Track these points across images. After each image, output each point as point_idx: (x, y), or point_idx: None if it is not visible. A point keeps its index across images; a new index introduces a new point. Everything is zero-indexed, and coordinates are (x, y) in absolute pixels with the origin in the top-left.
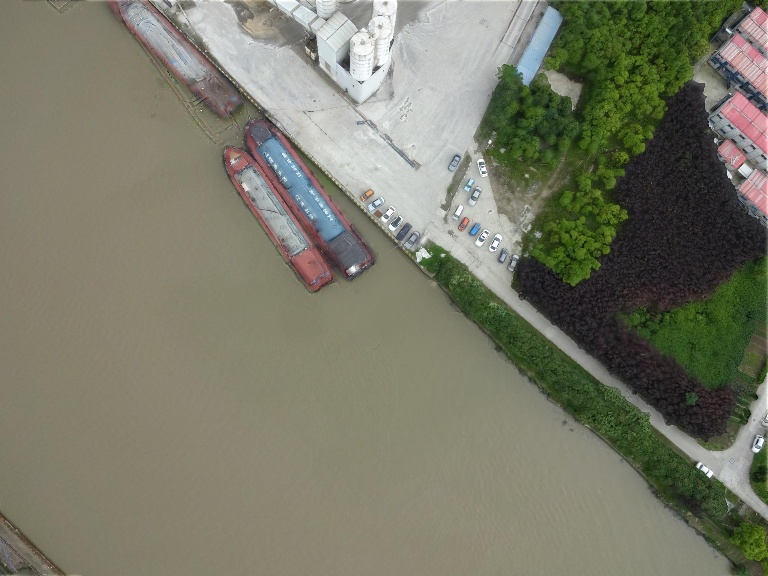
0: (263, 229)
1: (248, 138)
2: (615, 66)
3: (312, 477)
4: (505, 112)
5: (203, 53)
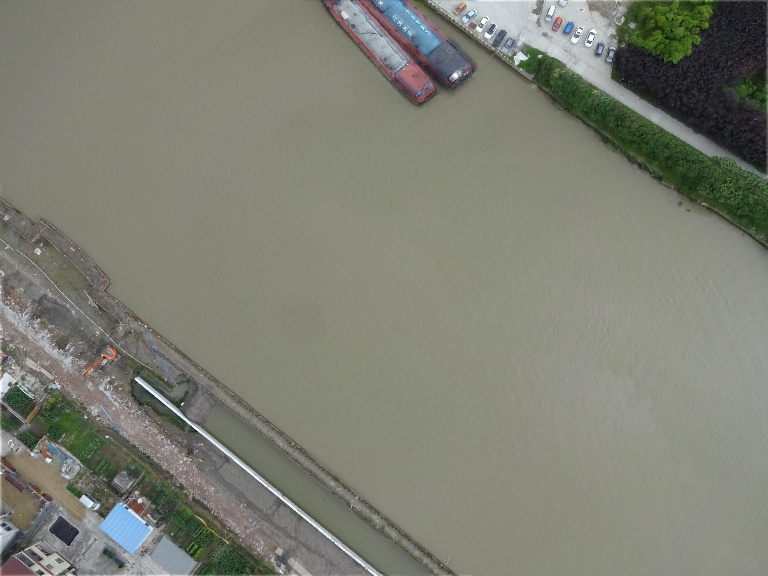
0: (365, 54)
1: None
2: None
3: (438, 277)
4: None
5: None
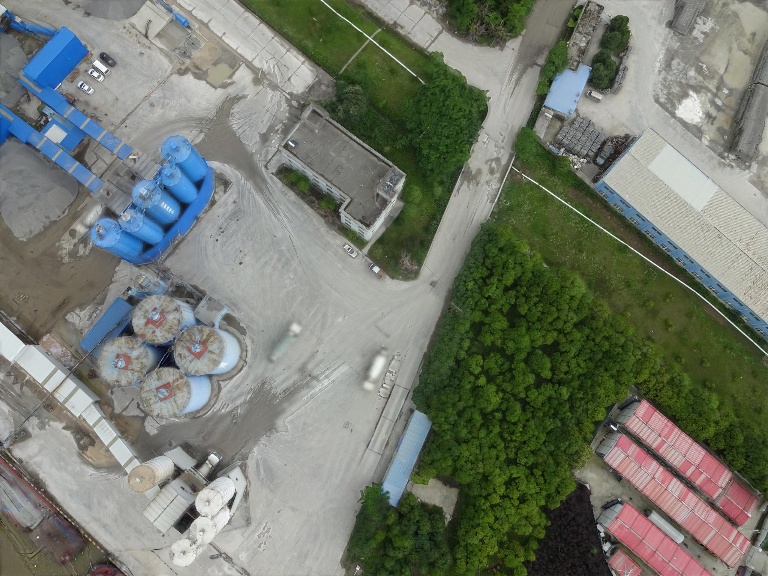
0: None
1: None
2: (489, 482)
3: None
4: (369, 545)
5: (39, 492)
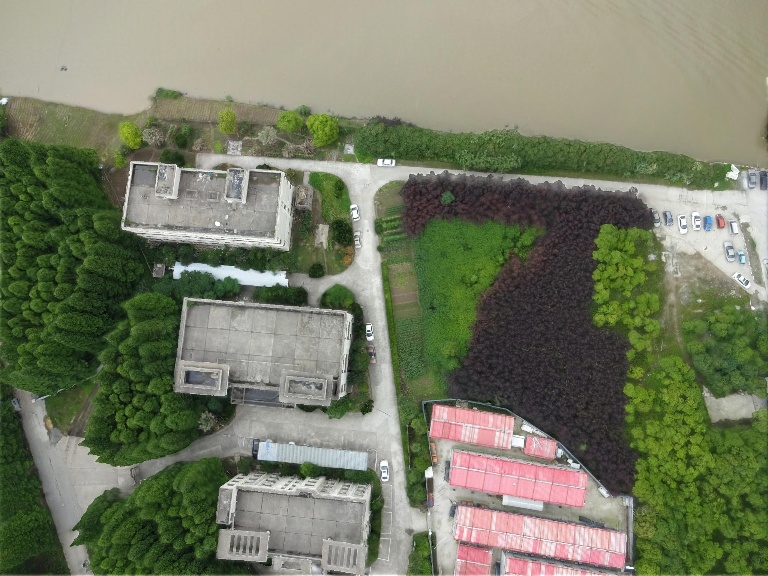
0: None
1: None
2: None
3: None
4: None
5: None
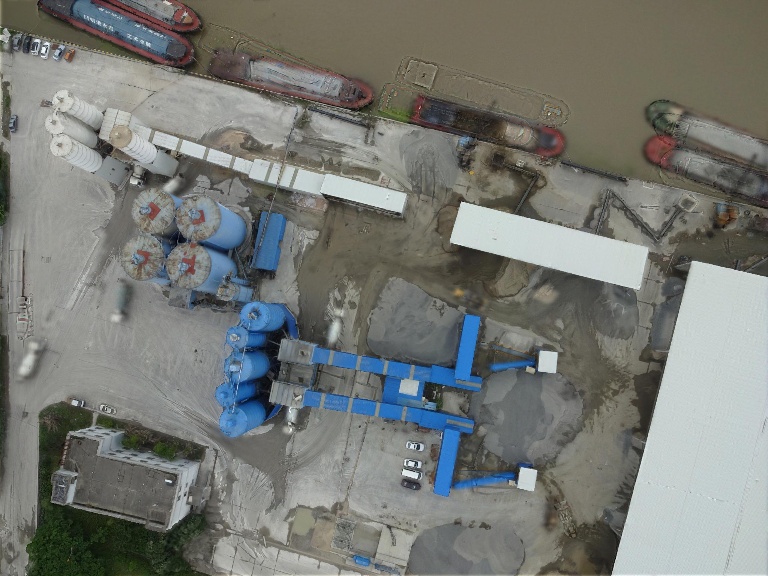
0: None
1: (188, 44)
2: None
3: None
4: None
5: (263, 89)
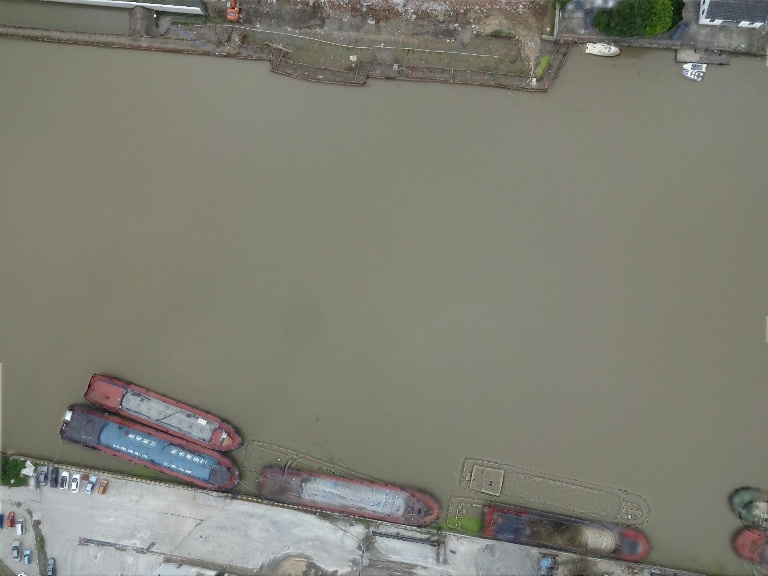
0: (169, 397)
1: (231, 464)
2: None
3: (5, 238)
4: None
5: (319, 511)
